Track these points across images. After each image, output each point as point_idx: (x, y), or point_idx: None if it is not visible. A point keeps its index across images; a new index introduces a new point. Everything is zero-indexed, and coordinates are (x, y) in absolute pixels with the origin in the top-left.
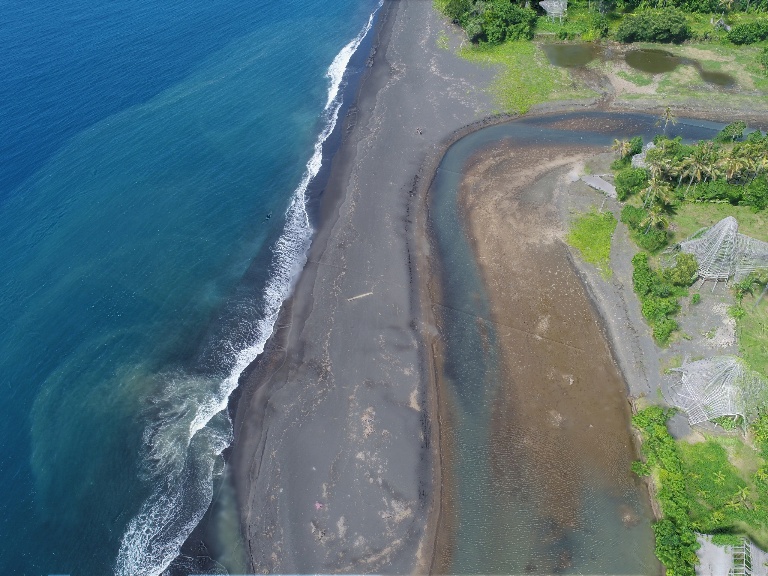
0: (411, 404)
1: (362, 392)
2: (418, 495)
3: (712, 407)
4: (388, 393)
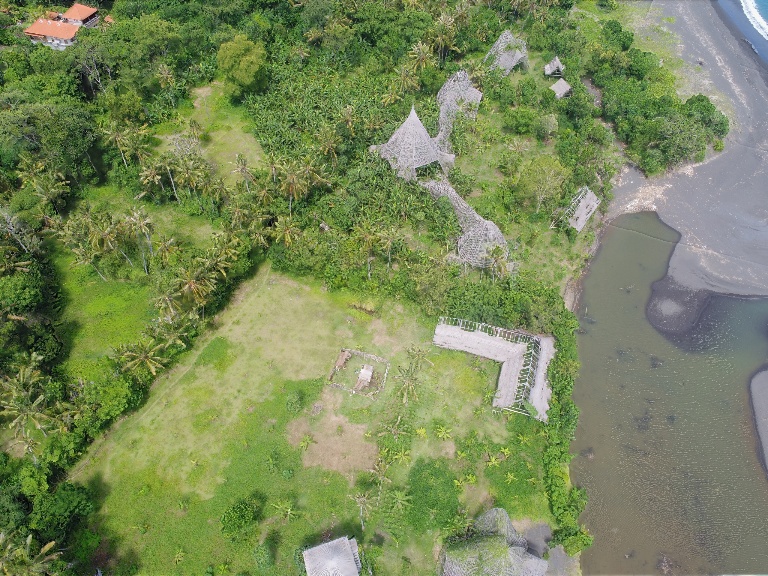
0: None
1: None
2: None
3: (517, 534)
4: None
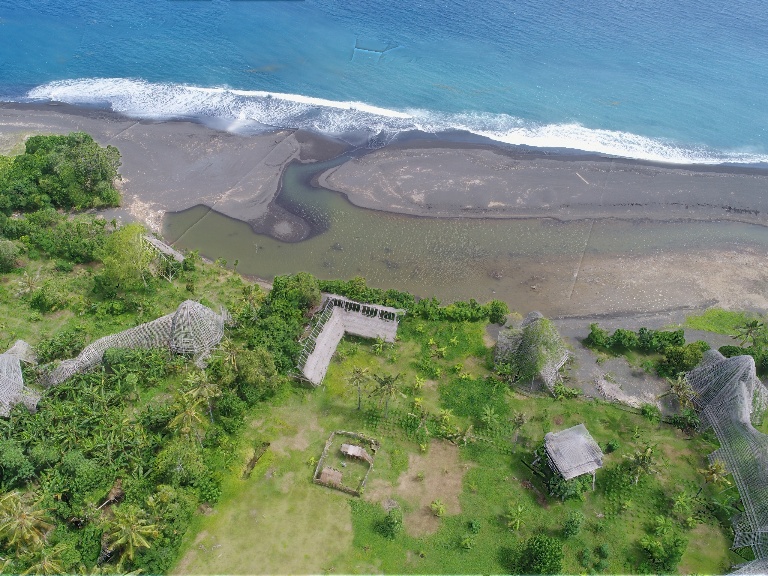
0: (493, 202)
1: (496, 180)
2: (428, 203)
3: None
4: (499, 192)
